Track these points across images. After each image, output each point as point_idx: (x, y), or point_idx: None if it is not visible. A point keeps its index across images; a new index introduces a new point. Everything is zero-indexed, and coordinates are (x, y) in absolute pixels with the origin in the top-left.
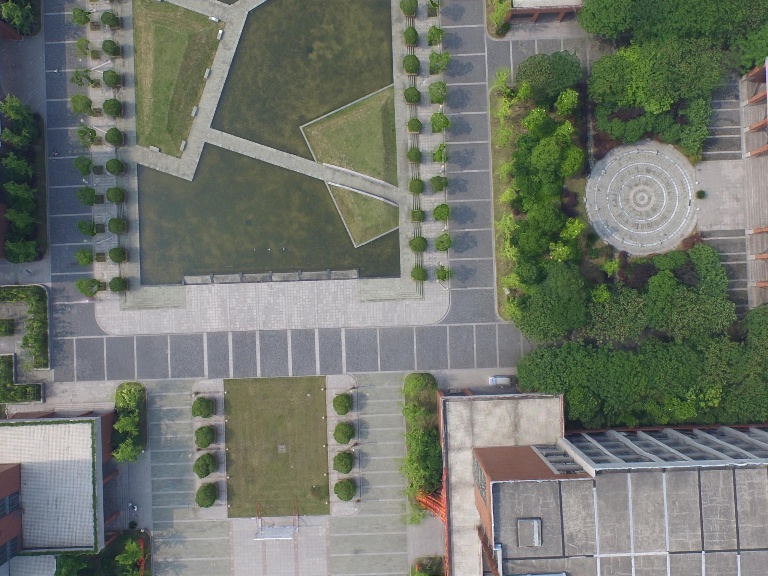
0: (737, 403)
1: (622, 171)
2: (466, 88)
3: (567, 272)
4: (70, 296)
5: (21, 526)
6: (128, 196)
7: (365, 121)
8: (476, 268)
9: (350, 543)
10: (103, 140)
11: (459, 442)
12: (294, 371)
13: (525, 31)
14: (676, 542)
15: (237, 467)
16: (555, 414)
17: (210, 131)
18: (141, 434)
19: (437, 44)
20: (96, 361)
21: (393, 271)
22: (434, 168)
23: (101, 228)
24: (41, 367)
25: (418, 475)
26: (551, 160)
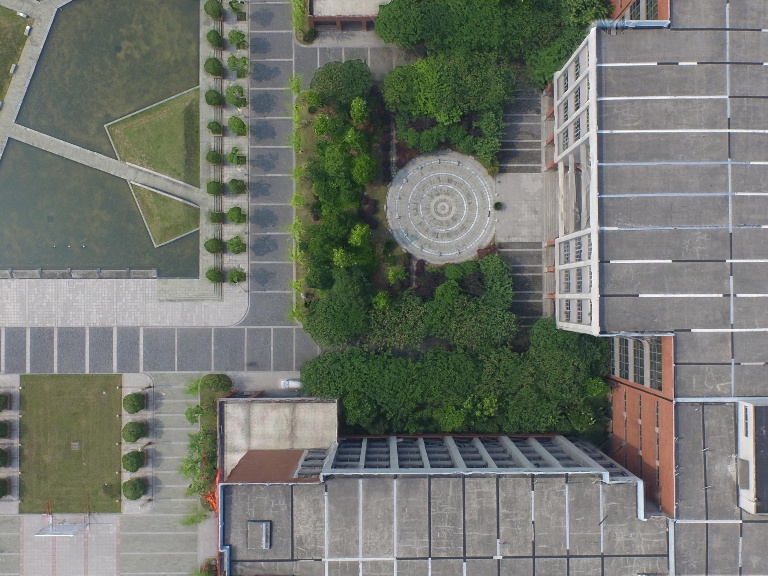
0: (518, 413)
1: (424, 180)
2: (273, 93)
3: (345, 278)
4: None
5: None
6: None
7: (167, 122)
8: (276, 272)
9: (140, 542)
10: None
11: (236, 444)
12: (91, 368)
13: (333, 38)
14: (404, 548)
15: (30, 463)
16: (332, 419)
17: (14, 126)
18: None
19: (245, 48)
20: None
21: (192, 272)
22: (238, 171)
23: None
24: None
25: (196, 475)
26: (336, 167)
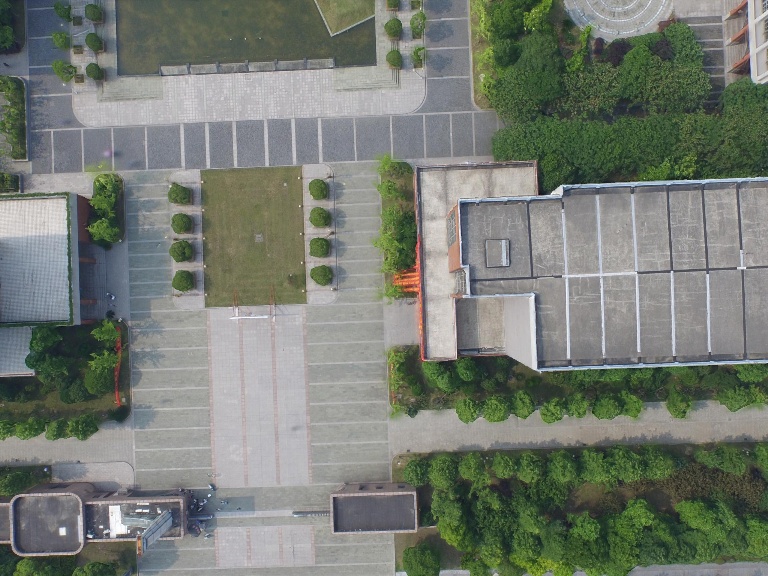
0: None
1: None
2: None
3: (540, 37)
4: (48, 89)
5: None
6: None
7: None
8: (452, 57)
9: (327, 332)
10: None
11: (433, 211)
12: (271, 161)
13: None
14: (645, 262)
15: (214, 257)
16: (529, 183)
17: None
18: (118, 223)
19: None
20: (74, 153)
21: (369, 60)
22: None
23: (78, 20)
24: (19, 156)
25: (392, 247)
26: None
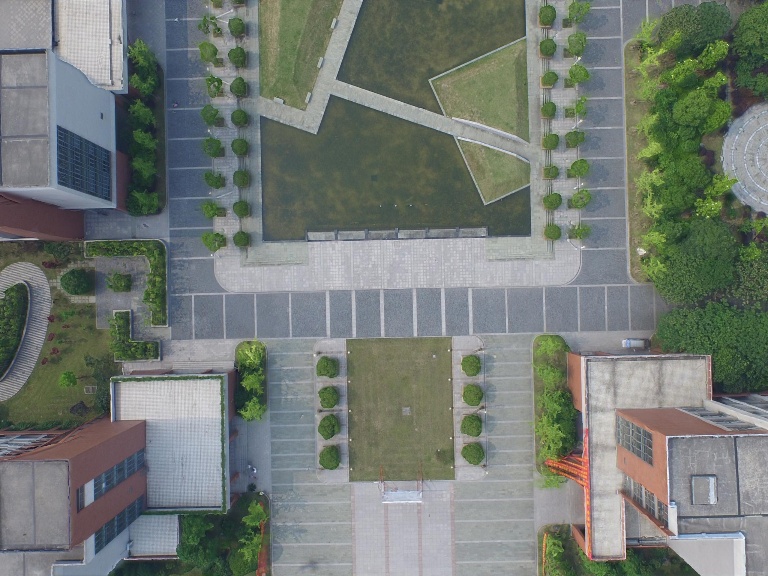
0: None
1: (760, 130)
2: (600, 42)
3: (717, 228)
4: (189, 252)
5: (146, 485)
6: (251, 149)
7: (498, 74)
8: (608, 228)
9: (475, 509)
10: (225, 91)
11: (601, 403)
12: (419, 331)
13: None
14: None
15: (360, 429)
16: (701, 376)
17: (336, 83)
18: (262, 394)
19: None
20: (215, 319)
21: (523, 230)
22: (566, 124)
23: (222, 182)
24: (160, 324)
25: (556, 437)
26: (700, 113)
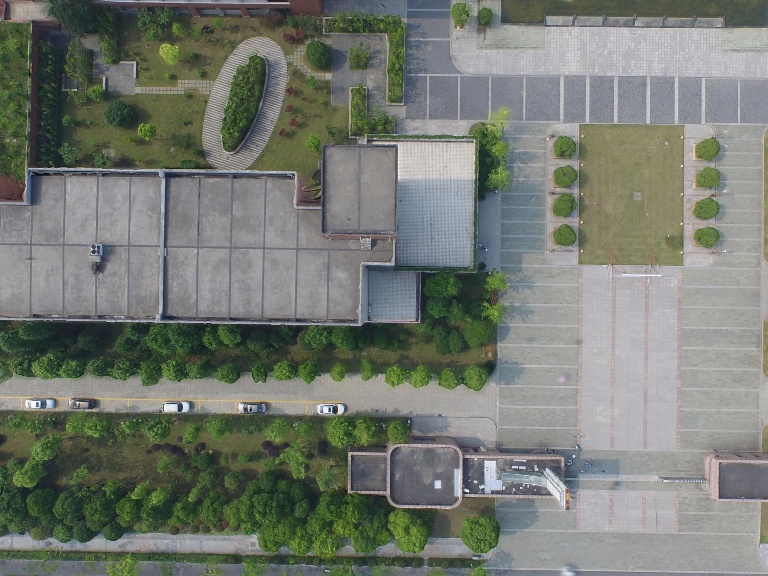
0: None
1: None
2: None
3: None
4: (425, 33)
5: None
6: None
7: None
8: None
9: (702, 295)
10: None
11: None
12: (652, 119)
13: None
14: None
15: (590, 213)
16: None
17: None
18: None
19: None
20: (449, 100)
21: (759, 21)
22: None
23: None
24: (398, 99)
25: None
26: None
